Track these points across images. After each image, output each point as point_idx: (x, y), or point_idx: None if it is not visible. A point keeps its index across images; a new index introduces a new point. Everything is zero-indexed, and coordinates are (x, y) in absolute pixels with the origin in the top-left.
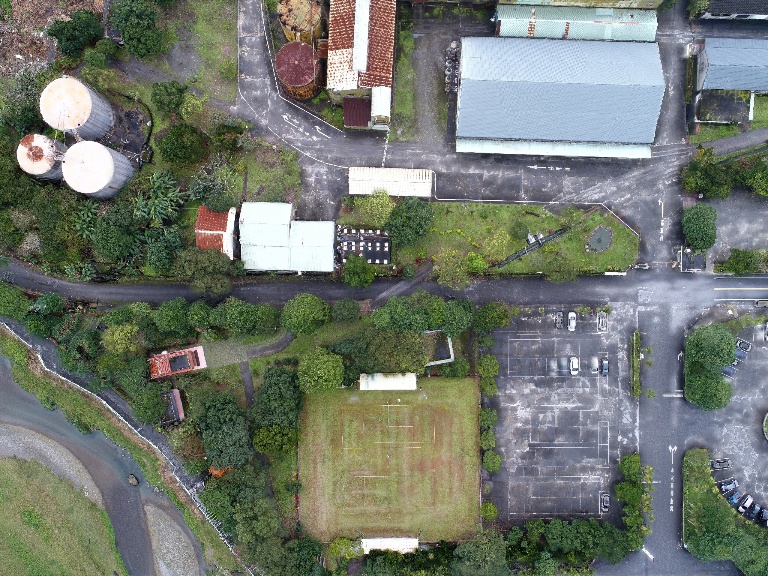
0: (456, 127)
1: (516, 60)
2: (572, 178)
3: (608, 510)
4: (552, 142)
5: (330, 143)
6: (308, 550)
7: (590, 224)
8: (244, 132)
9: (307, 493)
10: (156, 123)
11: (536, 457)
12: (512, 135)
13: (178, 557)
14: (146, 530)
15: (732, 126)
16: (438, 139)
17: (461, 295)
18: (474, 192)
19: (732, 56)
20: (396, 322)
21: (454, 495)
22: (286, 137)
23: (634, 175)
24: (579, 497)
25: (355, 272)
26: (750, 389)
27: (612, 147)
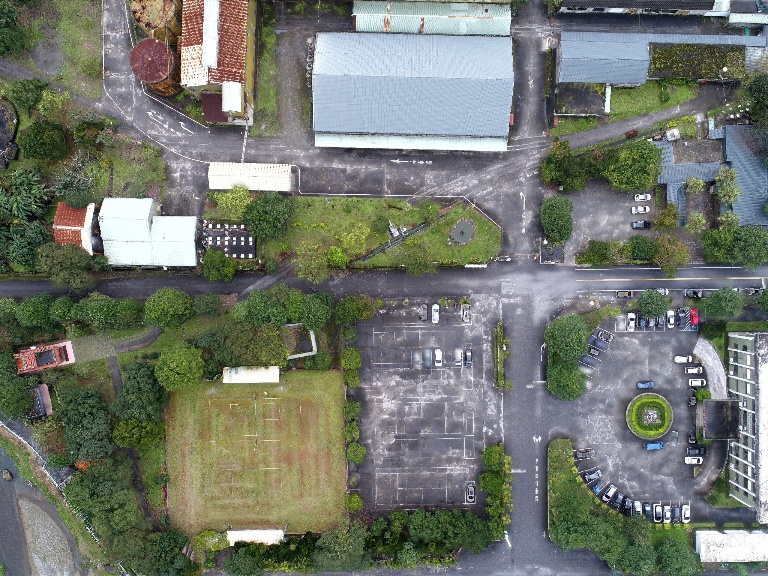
0: None
1: (369, 55)
2: (434, 172)
3: (474, 500)
4: (409, 136)
5: (195, 139)
6: (169, 542)
7: (453, 217)
8: (105, 128)
9: (176, 486)
10: (22, 120)
11: (402, 448)
12: (368, 129)
13: (52, 551)
14: (20, 525)
15: (590, 119)
16: (301, 134)
17: (326, 288)
18: (337, 186)
19: (586, 49)
20: (254, 315)
21: (321, 487)
22: (151, 133)
23: (495, 168)
24: (445, 488)
25: (214, 266)
26: (613, 379)
27: (469, 140)
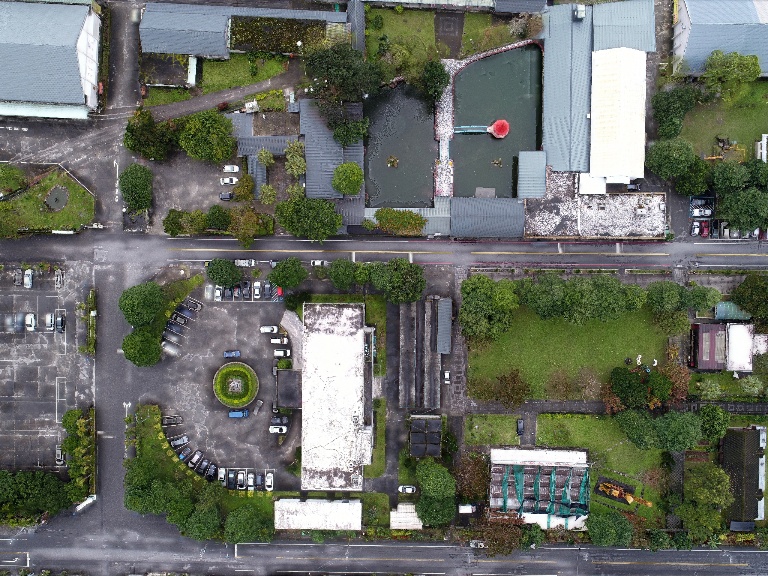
0: None
1: None
2: (30, 138)
3: (65, 464)
4: None
5: None
6: None
7: (47, 184)
8: None
9: None
10: None
11: None
12: None
13: None
14: None
15: (178, 90)
16: None
17: None
18: None
19: (166, 20)
20: None
21: None
22: None
23: (90, 136)
24: (37, 450)
25: None
26: (202, 348)
27: (50, 107)
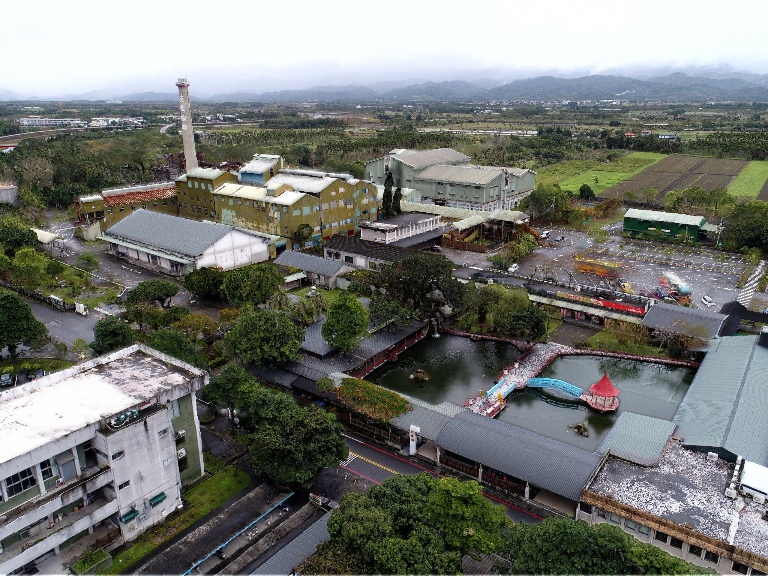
0: (110, 228)
1: None
2: (134, 275)
3: None
4: None
5: None
6: None
7: None
8: None
9: None
10: None
11: None
12: None
13: None
14: None
15: None
16: None
17: None
18: None
19: None
20: None
21: None
22: None
23: None
24: None
25: None
26: None
27: None
